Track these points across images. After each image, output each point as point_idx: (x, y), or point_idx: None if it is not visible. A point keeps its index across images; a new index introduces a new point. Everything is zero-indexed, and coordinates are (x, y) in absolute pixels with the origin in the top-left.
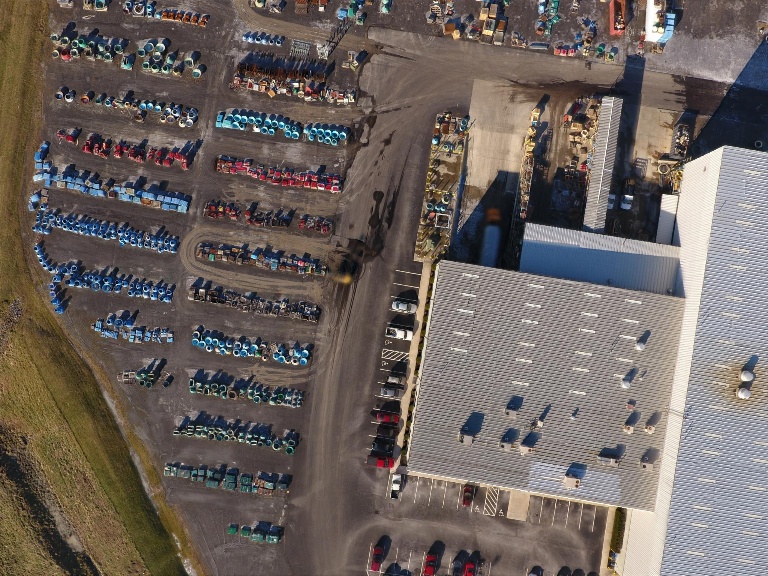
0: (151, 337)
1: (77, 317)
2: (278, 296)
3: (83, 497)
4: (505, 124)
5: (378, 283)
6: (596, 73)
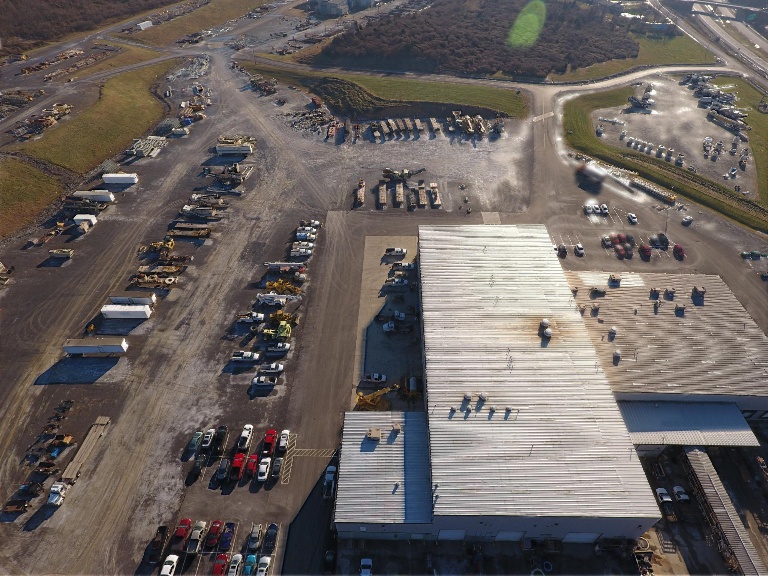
0: None
1: None
2: None
3: None
4: None
5: None
6: None
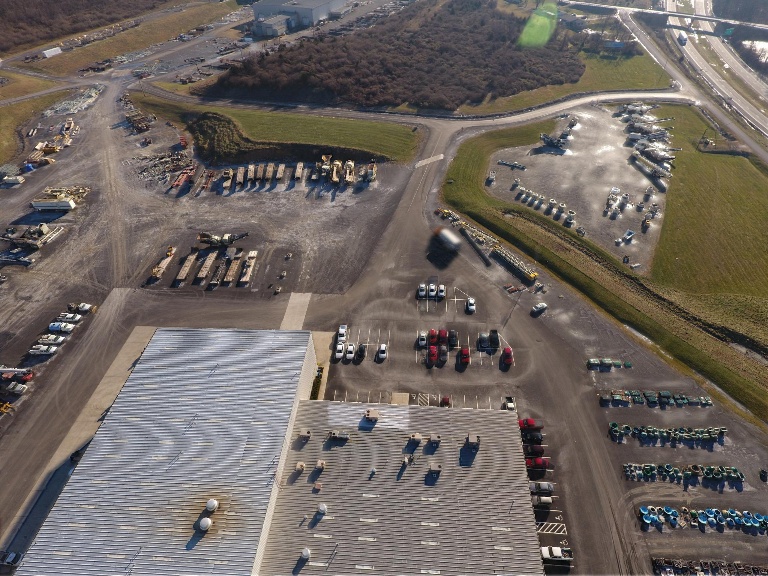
0: None
1: None
2: None
3: (761, 376)
4: None
5: None
6: None
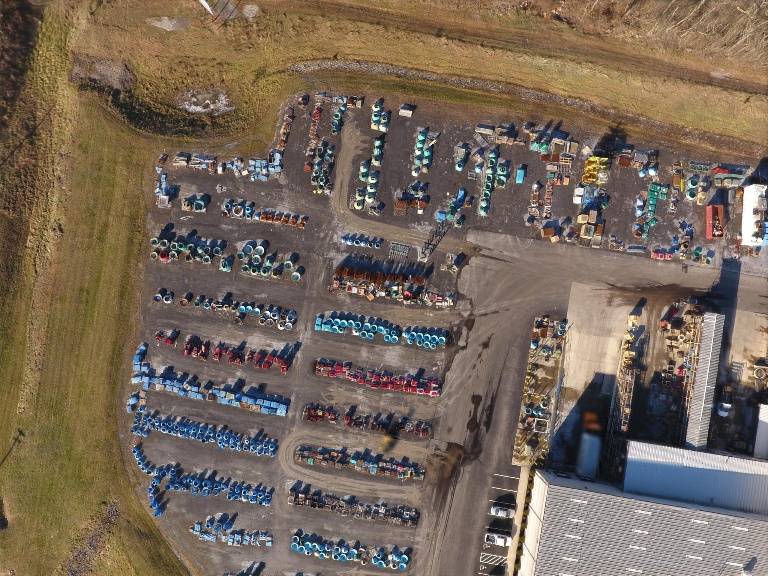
0: (250, 540)
1: (175, 519)
2: (377, 500)
3: None
4: (602, 328)
5: (476, 487)
6: (692, 276)
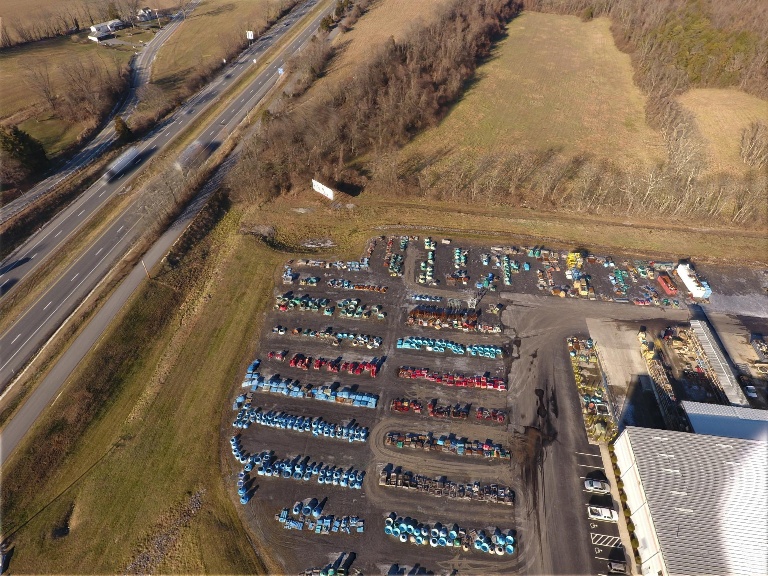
0: (339, 527)
1: (261, 507)
2: (468, 480)
3: None
4: (621, 343)
5: (563, 465)
6: (671, 314)
